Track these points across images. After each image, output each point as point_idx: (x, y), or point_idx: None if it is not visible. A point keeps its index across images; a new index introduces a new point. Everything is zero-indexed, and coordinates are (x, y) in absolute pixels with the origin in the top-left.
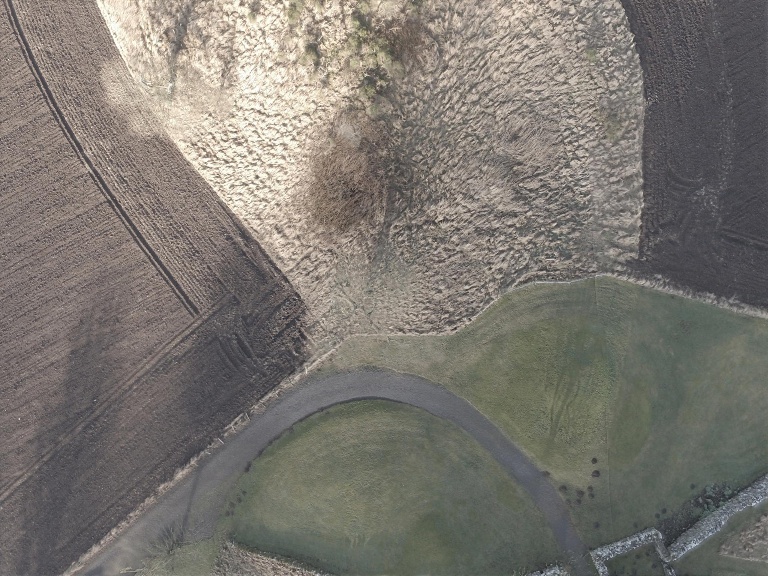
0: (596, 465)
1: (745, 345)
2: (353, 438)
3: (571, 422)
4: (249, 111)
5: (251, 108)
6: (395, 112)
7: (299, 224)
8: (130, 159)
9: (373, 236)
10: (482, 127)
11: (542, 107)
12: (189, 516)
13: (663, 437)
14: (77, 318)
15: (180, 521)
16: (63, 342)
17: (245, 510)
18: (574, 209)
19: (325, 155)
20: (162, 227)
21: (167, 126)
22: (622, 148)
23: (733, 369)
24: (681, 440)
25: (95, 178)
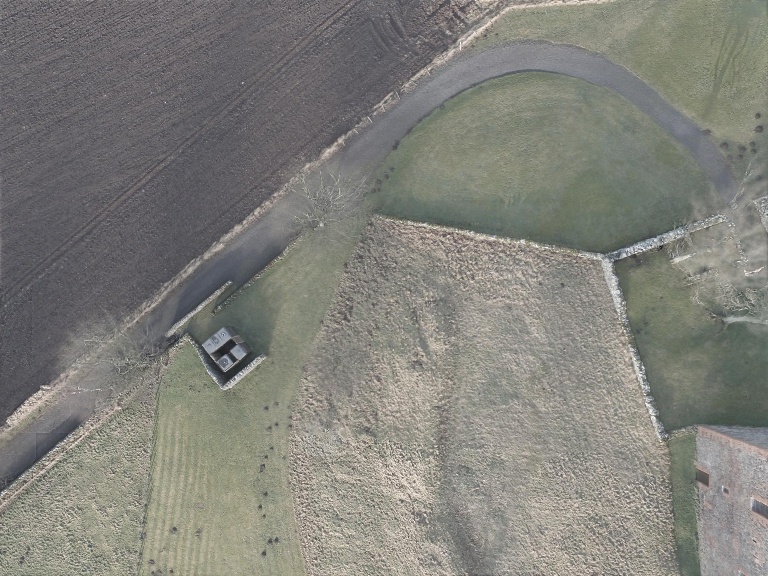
0: (759, 120)
1: None
2: (508, 107)
3: (736, 76)
4: None
5: None
6: None
7: None
8: None
9: None
10: None
11: None
12: None
13: None
14: (229, 1)
15: None
16: (213, 25)
17: (393, 184)
18: None
19: None
20: None
21: None
22: None
23: None
24: None
25: None
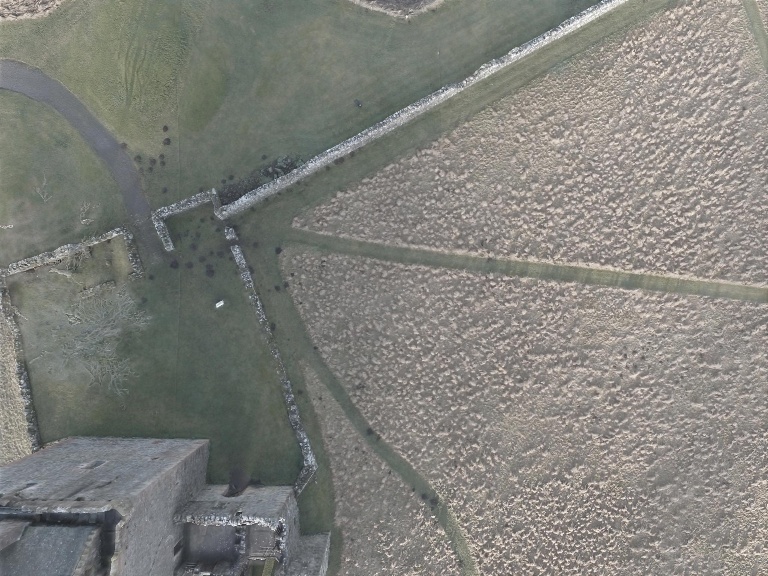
0: (167, 133)
1: (331, 28)
2: None
3: (143, 89)
4: None
5: None
6: None
7: None
8: None
9: None
10: None
11: None
12: None
13: (236, 108)
14: None
15: None
16: None
17: None
18: None
19: None
20: None
21: None
22: None
23: (317, 50)
24: (255, 112)
25: None
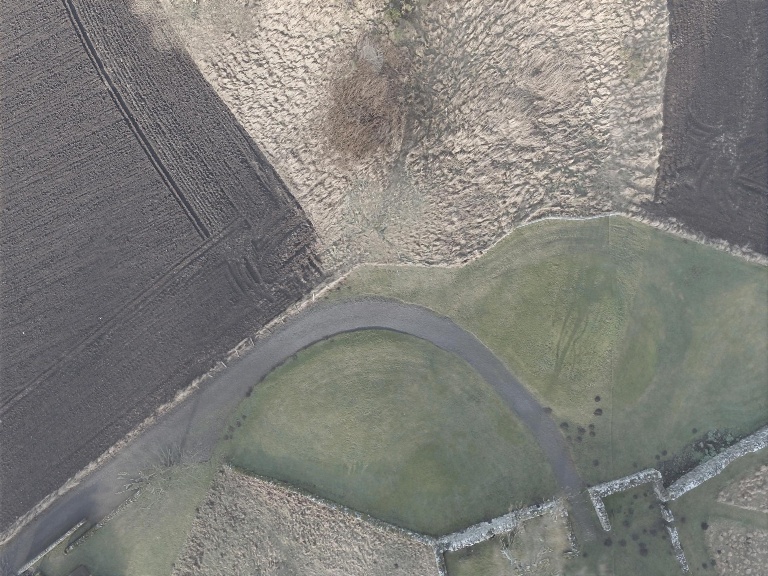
0: (599, 403)
1: (756, 294)
2: (357, 367)
3: (577, 359)
4: (272, 32)
5: (274, 29)
6: (418, 39)
7: (315, 149)
8: (150, 77)
9: (389, 164)
10: (505, 60)
11: (566, 43)
12: (188, 438)
13: (668, 380)
14: (87, 235)
15: (178, 443)
16: (72, 258)
17: (244, 434)
18: (592, 147)
19: (346, 78)
20: (178, 147)
21: (189, 45)
22: (644, 89)
23: (742, 317)
24: (686, 384)
25: (113, 95)
